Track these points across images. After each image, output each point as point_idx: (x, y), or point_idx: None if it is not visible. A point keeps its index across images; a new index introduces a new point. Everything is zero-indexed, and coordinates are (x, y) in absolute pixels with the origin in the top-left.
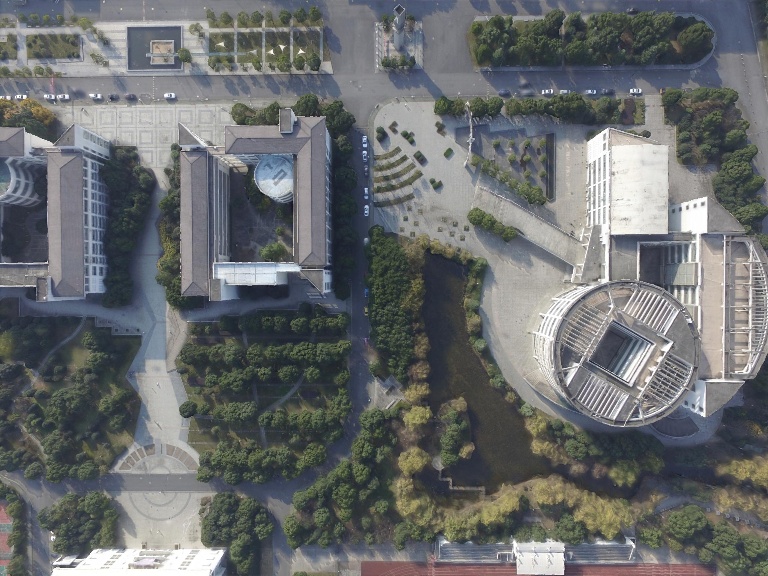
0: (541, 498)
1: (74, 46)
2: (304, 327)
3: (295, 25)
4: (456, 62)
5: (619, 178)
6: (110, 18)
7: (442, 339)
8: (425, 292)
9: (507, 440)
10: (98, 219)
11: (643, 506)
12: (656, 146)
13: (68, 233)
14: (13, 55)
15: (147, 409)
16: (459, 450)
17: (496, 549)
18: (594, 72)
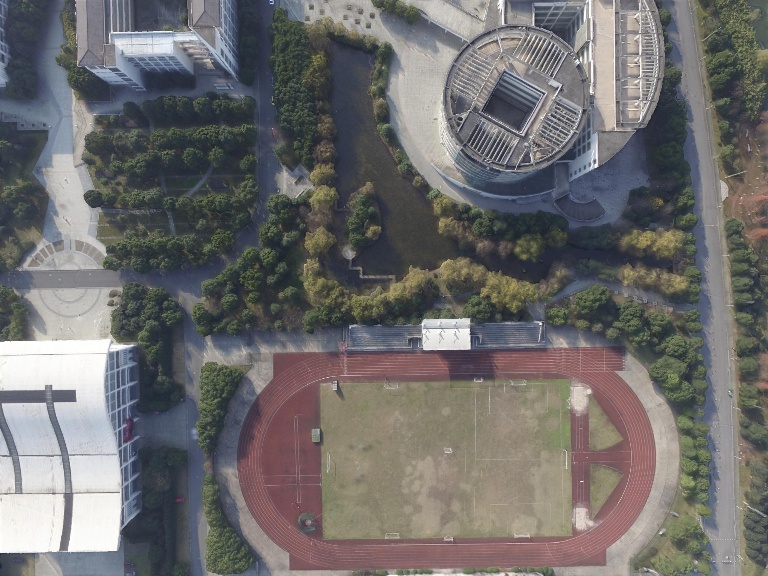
0: (446, 272)
1: None
2: (207, 107)
3: None
4: None
5: None
6: None
7: (350, 129)
8: (329, 73)
9: (417, 229)
10: None
11: (549, 283)
12: None
13: None
14: None
15: (55, 205)
16: (366, 231)
17: (406, 333)
18: None
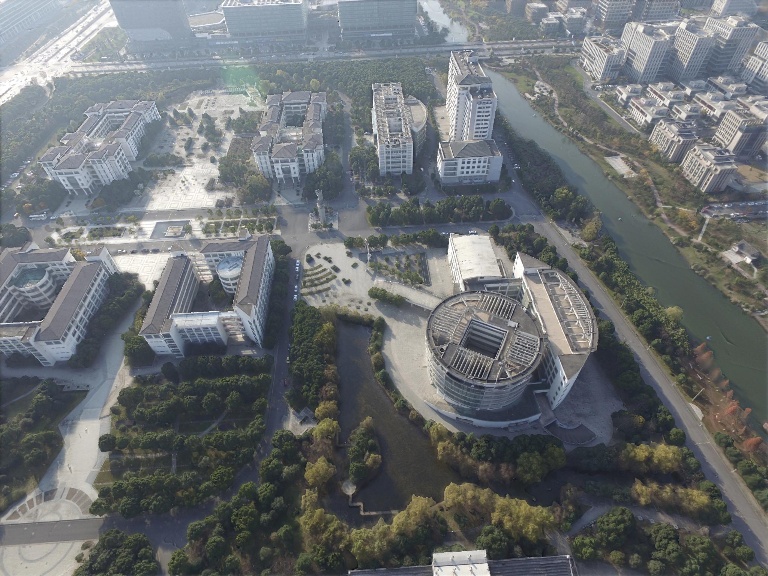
0: (450, 495)
1: (119, 231)
2: (233, 362)
3: (261, 217)
4: (359, 226)
5: (460, 251)
6: (148, 219)
7: (352, 378)
8: (335, 336)
9: (417, 460)
10: (93, 305)
11: None
12: (480, 236)
13: (69, 300)
14: (78, 236)
15: (66, 453)
16: (366, 460)
17: None
18: (445, 226)
